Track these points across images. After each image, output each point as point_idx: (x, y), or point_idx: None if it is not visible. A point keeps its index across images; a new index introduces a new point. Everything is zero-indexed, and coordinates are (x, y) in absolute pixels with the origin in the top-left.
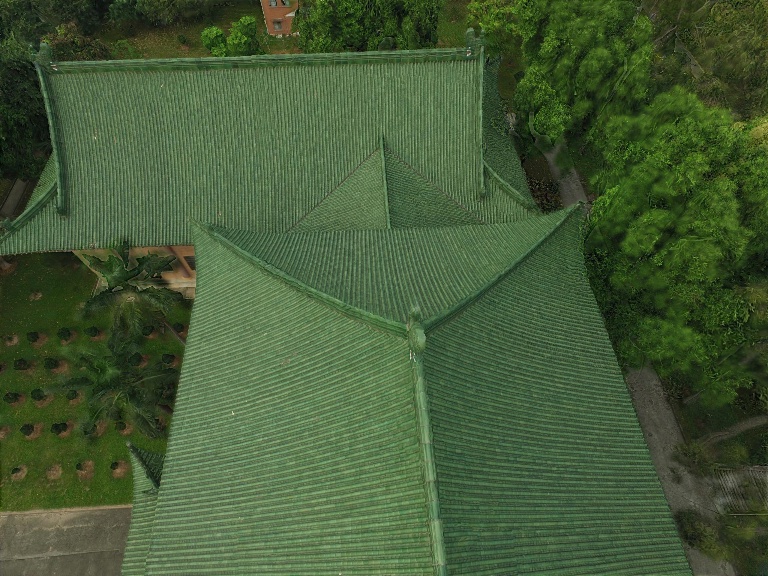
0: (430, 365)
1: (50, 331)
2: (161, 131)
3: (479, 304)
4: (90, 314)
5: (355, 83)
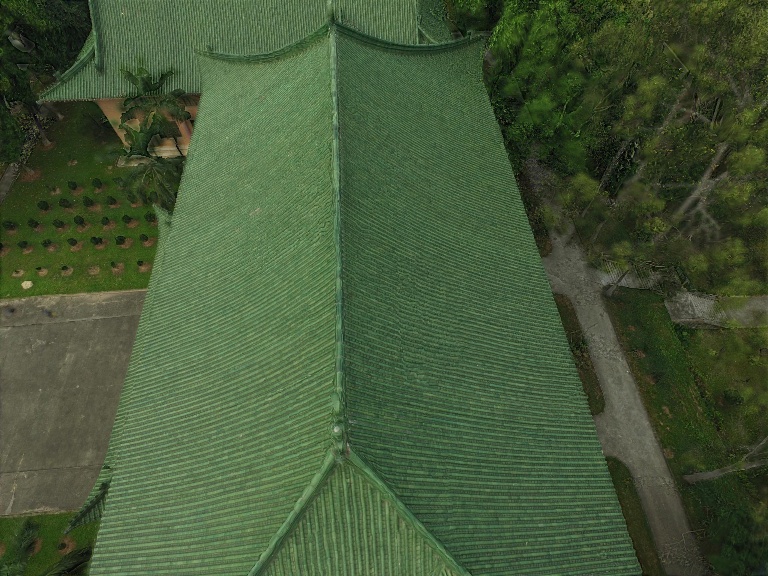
0: (343, 49)
1: (85, 184)
2: (172, 8)
3: (388, 55)
4: (116, 173)
5: None
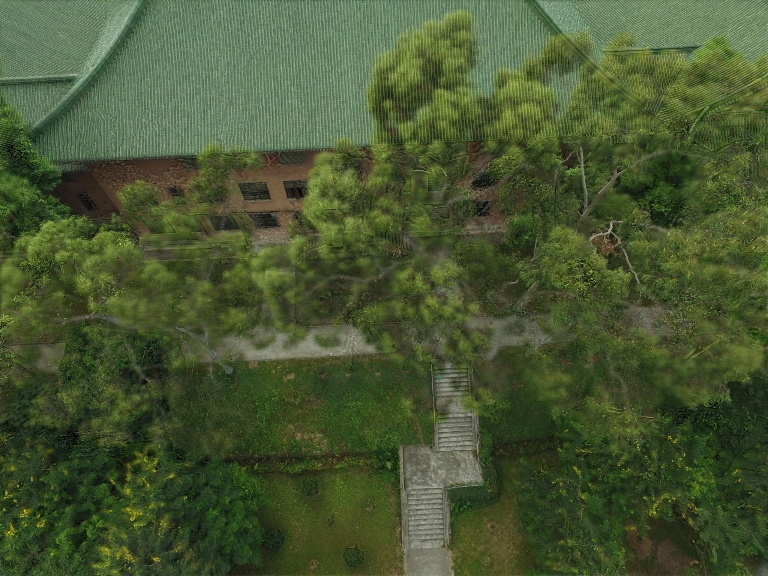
0: None
1: None
2: None
3: (527, 8)
4: None
5: (739, 4)
